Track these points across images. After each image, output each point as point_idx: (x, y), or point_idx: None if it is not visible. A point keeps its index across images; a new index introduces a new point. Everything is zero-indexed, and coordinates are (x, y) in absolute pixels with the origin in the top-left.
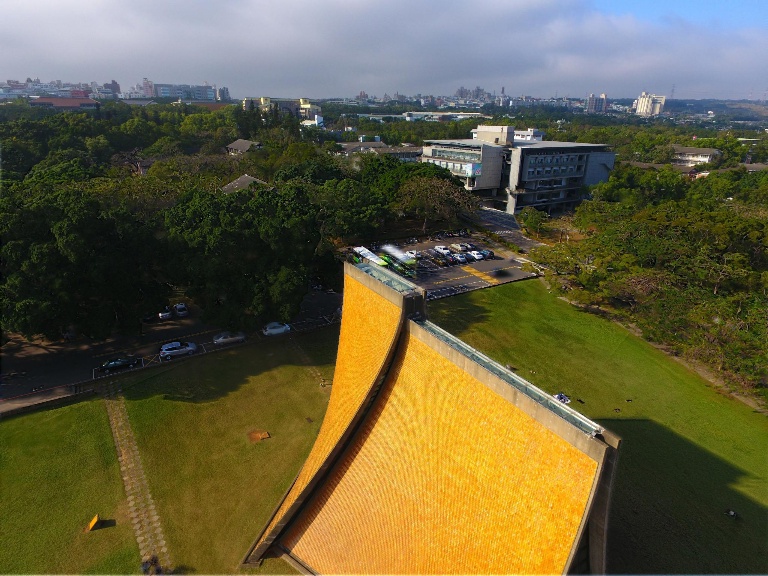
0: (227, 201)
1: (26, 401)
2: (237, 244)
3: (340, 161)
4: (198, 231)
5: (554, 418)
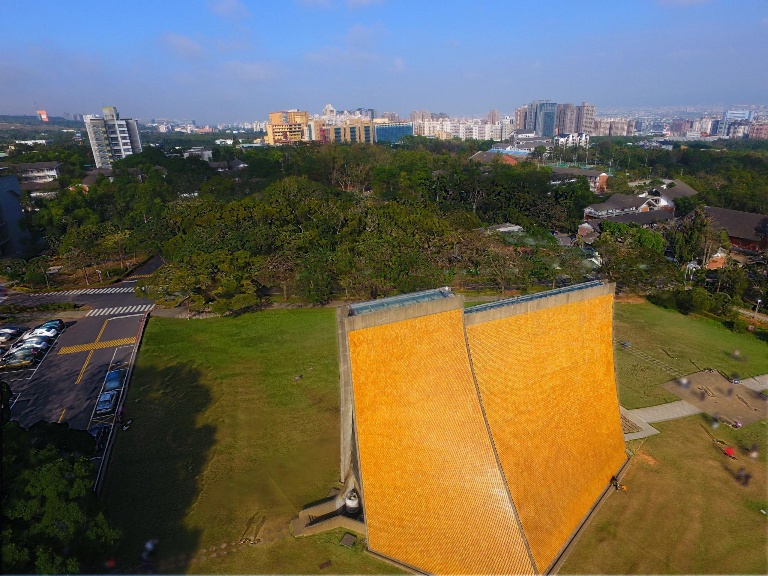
0: None
1: None
2: None
3: None
4: None
5: (592, 289)
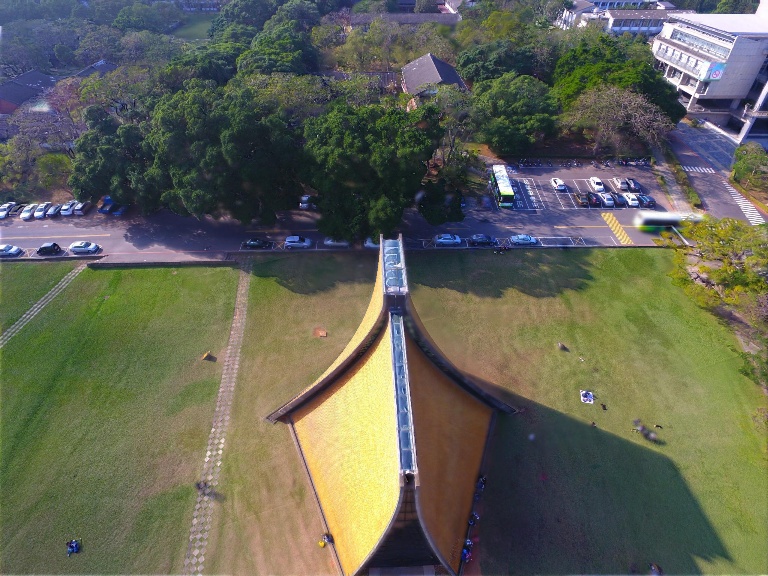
0: (356, 120)
1: (199, 257)
2: (351, 167)
3: (541, 40)
4: (324, 149)
5: None
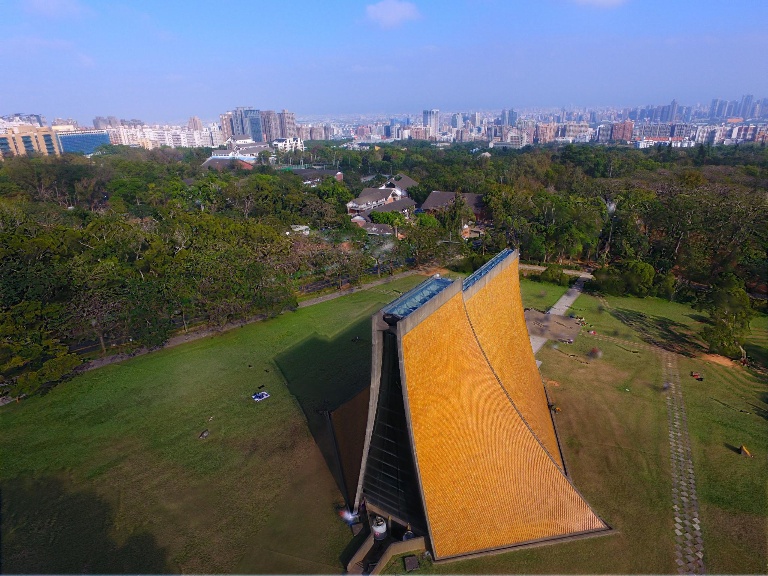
0: None
1: None
2: None
3: None
4: None
5: None
